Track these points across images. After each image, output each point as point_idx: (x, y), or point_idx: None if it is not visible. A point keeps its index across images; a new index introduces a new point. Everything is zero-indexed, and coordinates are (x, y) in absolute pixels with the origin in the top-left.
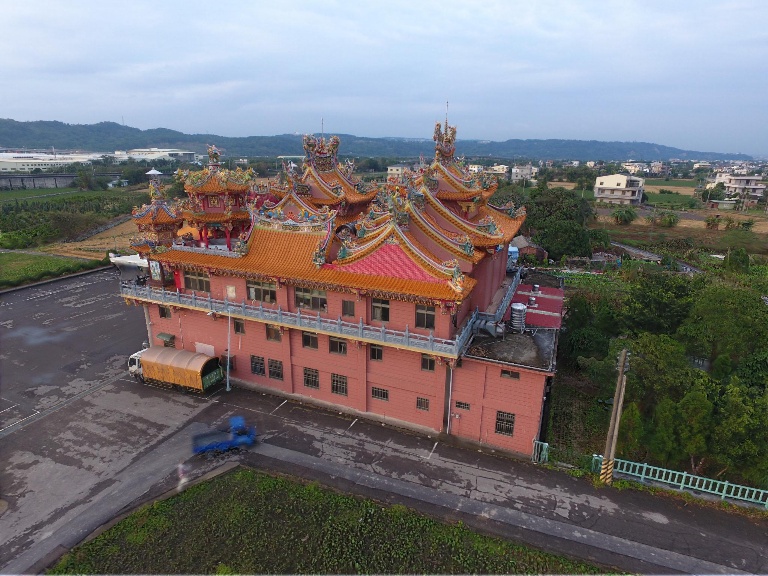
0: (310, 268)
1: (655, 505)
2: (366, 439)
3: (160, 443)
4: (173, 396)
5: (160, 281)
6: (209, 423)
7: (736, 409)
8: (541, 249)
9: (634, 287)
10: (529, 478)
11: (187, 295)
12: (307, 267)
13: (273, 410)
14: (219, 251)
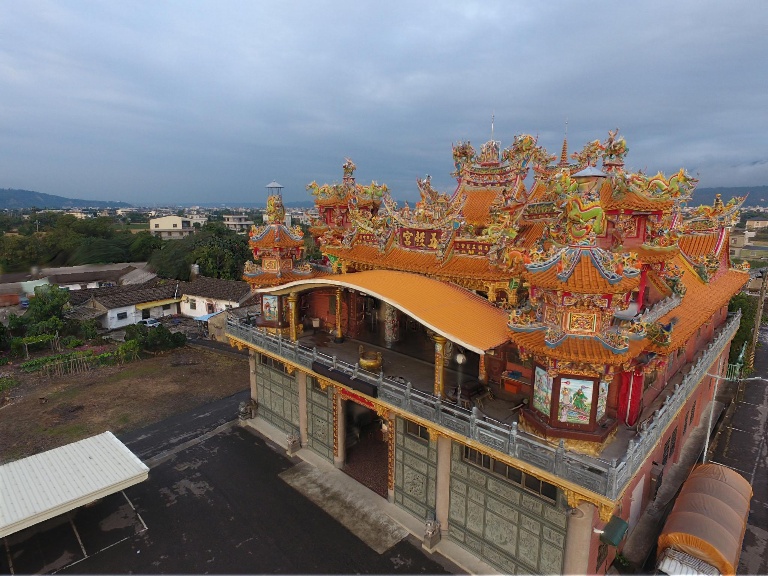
0: None
1: (763, 364)
2: (762, 427)
3: None
4: (748, 573)
5: (605, 416)
6: None
7: (750, 301)
8: None
9: None
10: (766, 384)
11: (673, 398)
12: None
13: (742, 471)
14: (672, 302)
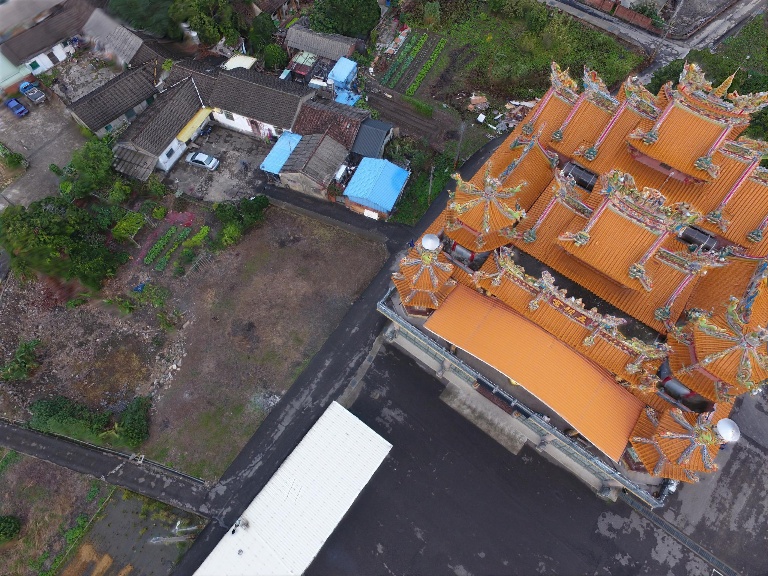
0: (767, 293)
1: None
2: None
3: (759, 445)
4: None
5: None
6: (733, 413)
7: None
8: (363, 42)
9: (651, 84)
10: None
11: None
12: (765, 294)
13: None
14: None
